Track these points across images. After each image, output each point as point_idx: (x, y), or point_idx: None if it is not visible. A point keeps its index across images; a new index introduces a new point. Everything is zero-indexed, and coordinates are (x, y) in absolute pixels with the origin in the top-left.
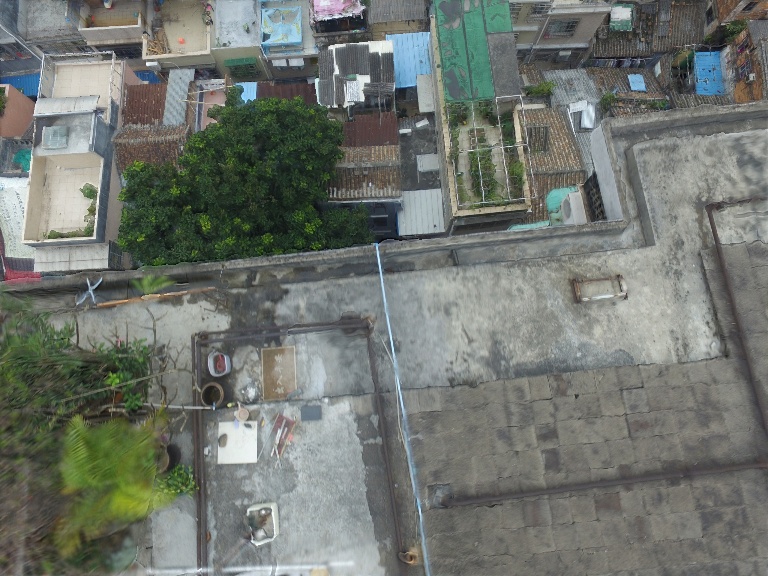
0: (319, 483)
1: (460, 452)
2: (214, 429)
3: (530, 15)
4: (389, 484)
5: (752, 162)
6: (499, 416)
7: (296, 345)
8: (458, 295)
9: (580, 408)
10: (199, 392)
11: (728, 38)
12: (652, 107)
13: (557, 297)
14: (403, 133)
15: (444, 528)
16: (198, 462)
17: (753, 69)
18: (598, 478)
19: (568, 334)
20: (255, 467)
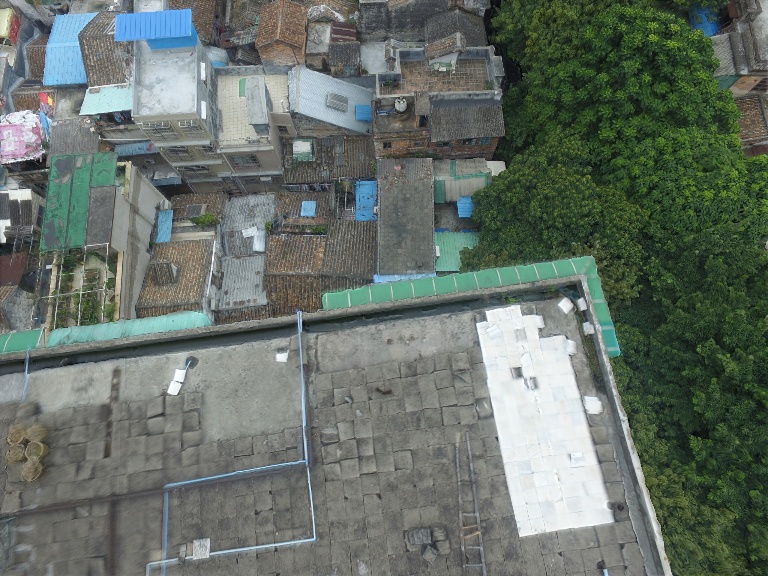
0: None
1: None
2: None
3: (201, 154)
4: None
5: None
6: None
7: None
8: None
9: None
10: None
11: (374, 171)
12: (314, 232)
13: None
14: (50, 268)
15: None
16: None
17: (377, 202)
18: None
19: None
20: None
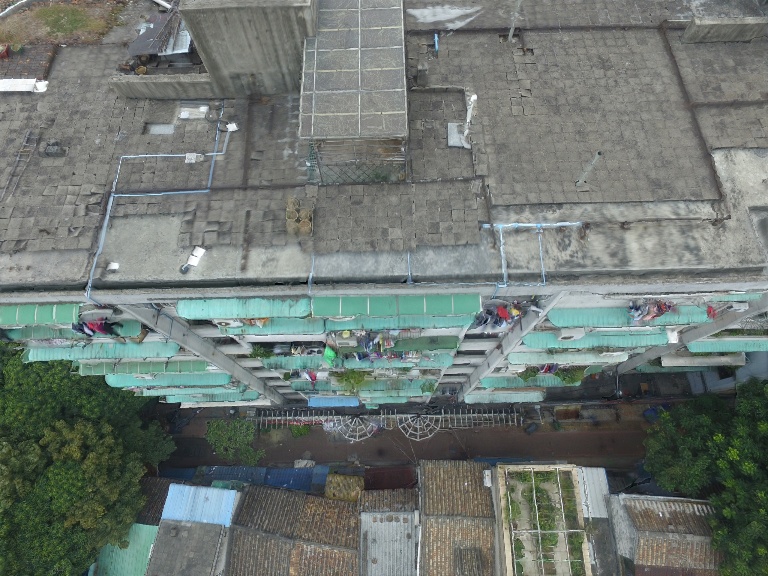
0: None
1: None
2: None
3: None
4: None
5: (691, 248)
6: None
7: None
8: None
9: None
10: None
11: None
12: None
13: None
14: None
15: None
16: None
17: None
18: None
19: None
20: None
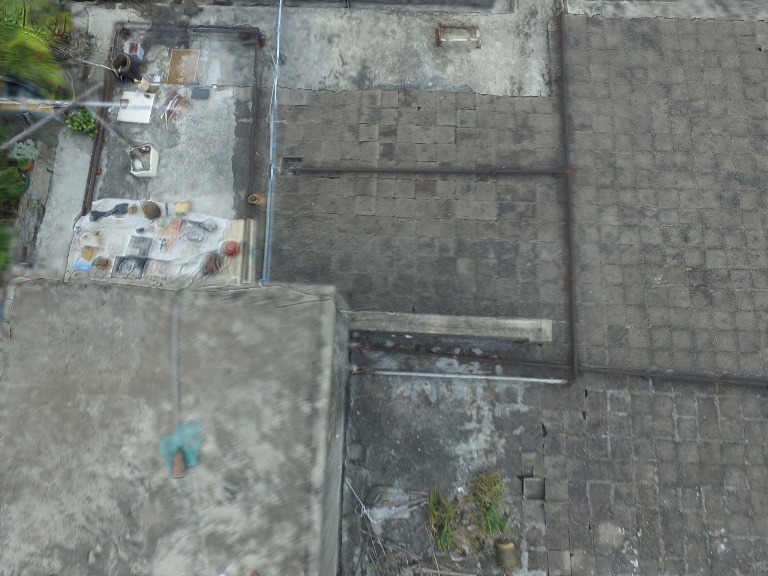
0: (196, 145)
1: (314, 136)
2: (119, 94)
3: None
4: (250, 147)
5: None
6: (353, 116)
7: (201, 50)
8: (342, 29)
9: (420, 118)
10: (111, 60)
11: None
12: None
13: (423, 41)
14: None
15: (290, 190)
16: (101, 114)
17: None
18: (422, 168)
19: (425, 69)
20: (147, 127)
